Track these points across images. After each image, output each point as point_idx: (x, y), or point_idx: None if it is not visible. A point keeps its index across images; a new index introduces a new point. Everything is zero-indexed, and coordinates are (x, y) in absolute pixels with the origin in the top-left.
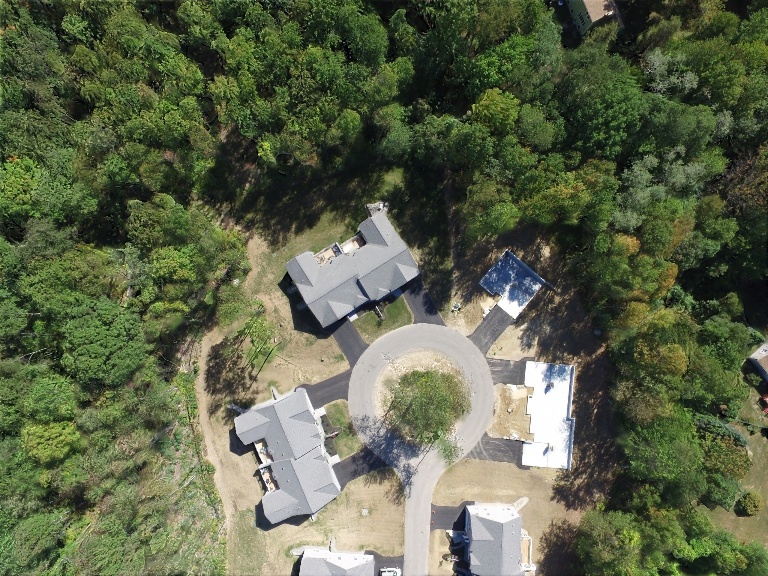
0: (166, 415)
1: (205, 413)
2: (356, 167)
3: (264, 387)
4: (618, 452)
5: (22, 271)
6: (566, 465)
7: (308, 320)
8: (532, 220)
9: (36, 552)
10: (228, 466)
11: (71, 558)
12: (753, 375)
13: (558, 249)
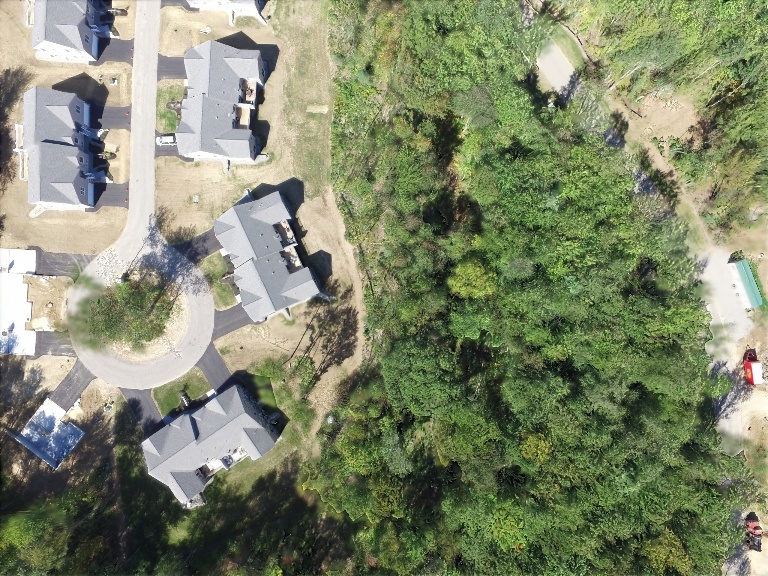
0: None
1: (357, 290)
2: (216, 542)
3: (299, 319)
4: None
5: (505, 440)
6: None
7: (256, 388)
8: (3, 521)
9: (478, 177)
10: (333, 240)
11: None
12: None
13: (3, 473)
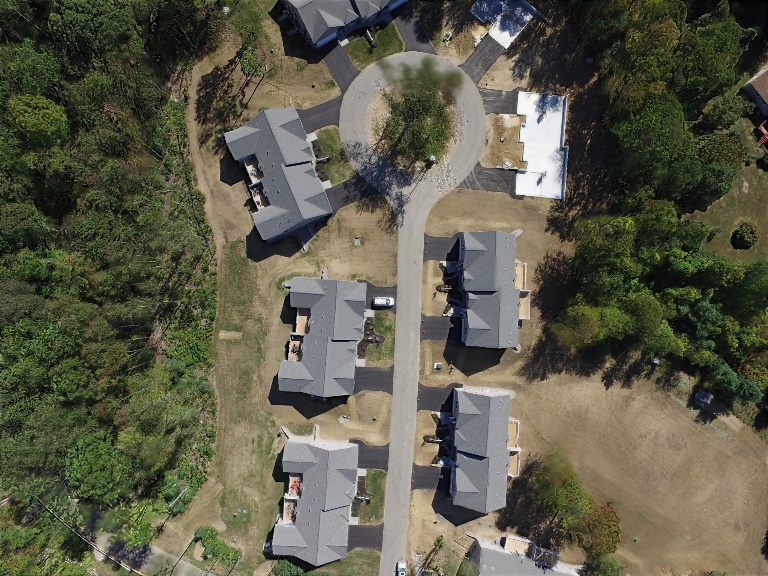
0: (156, 140)
1: (195, 143)
2: None
3: (255, 114)
4: (612, 182)
5: None
6: (560, 195)
7: (299, 44)
8: None
9: (22, 226)
10: (219, 196)
11: (59, 282)
12: (747, 102)
13: None
